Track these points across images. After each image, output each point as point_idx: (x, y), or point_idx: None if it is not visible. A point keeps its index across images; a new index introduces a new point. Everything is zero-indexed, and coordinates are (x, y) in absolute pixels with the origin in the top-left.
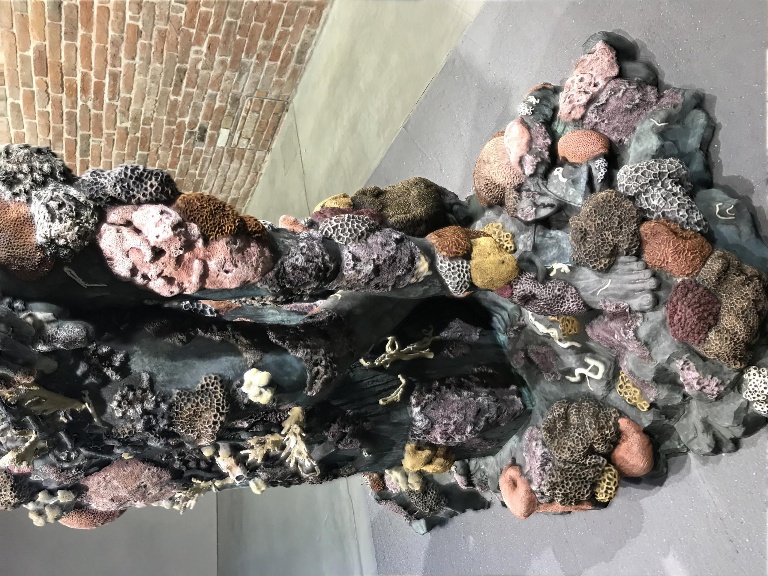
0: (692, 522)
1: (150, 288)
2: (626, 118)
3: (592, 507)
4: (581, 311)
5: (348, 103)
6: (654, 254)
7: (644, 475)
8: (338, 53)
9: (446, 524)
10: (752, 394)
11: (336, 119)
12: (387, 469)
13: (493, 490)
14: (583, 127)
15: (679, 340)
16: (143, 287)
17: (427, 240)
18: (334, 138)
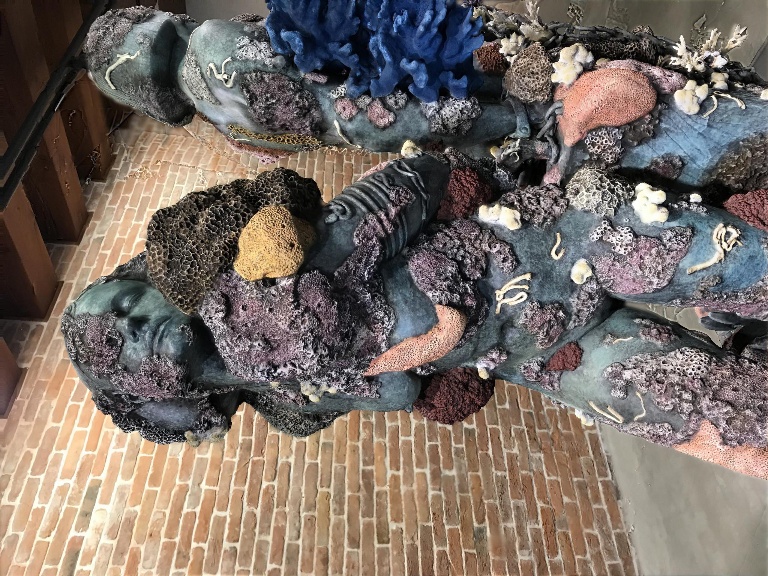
0: None
1: None
2: None
3: None
4: None
5: None
6: None
7: None
8: None
9: None
10: None
11: None
12: None
13: None
14: None
15: None
16: None
17: None
18: None
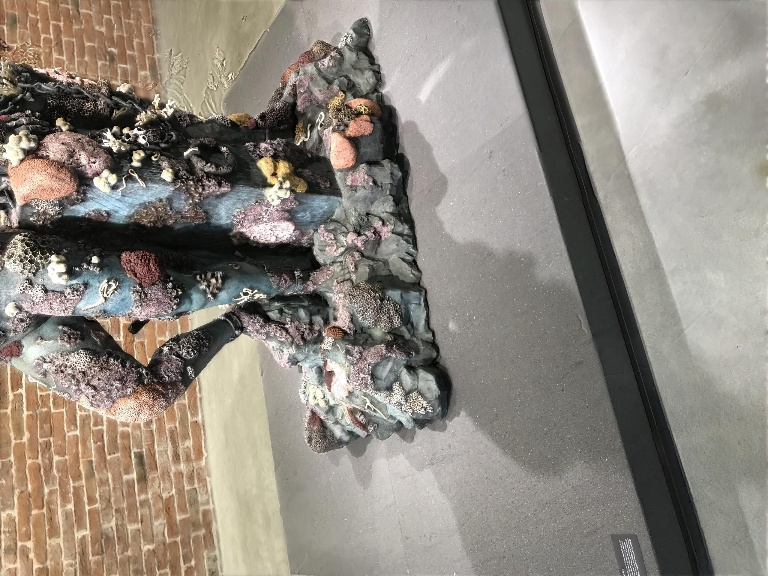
0: (405, 85)
1: (57, 80)
2: None
3: (367, 116)
4: (287, 105)
5: (256, 524)
6: (288, 78)
7: (382, 111)
8: (235, 528)
9: (448, 372)
10: (342, 41)
11: (258, 558)
12: (264, 189)
13: (350, 190)
14: None
15: (310, 62)
16: (54, 81)
17: None
18: (265, 569)
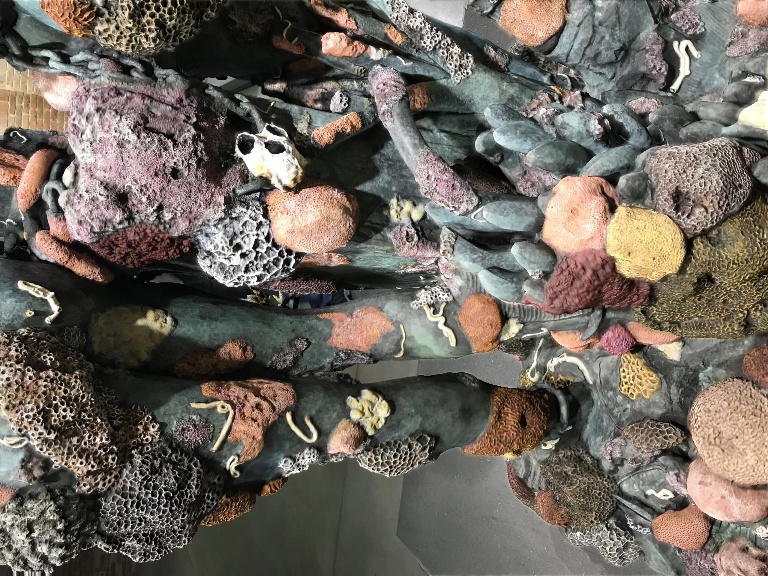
0: None
1: None
2: (694, 575)
3: None
4: None
5: None
6: None
7: None
8: None
9: None
10: None
11: None
12: None
13: None
14: (716, 545)
15: None
16: None
17: (468, 445)
18: None
